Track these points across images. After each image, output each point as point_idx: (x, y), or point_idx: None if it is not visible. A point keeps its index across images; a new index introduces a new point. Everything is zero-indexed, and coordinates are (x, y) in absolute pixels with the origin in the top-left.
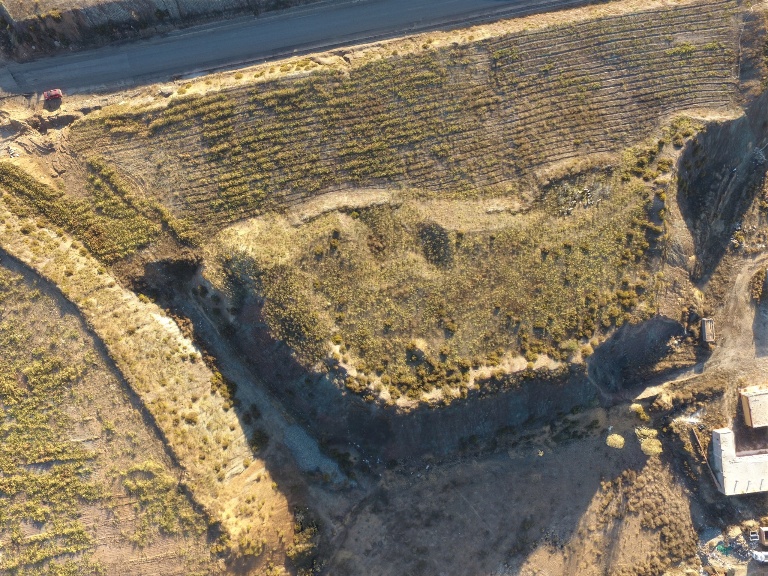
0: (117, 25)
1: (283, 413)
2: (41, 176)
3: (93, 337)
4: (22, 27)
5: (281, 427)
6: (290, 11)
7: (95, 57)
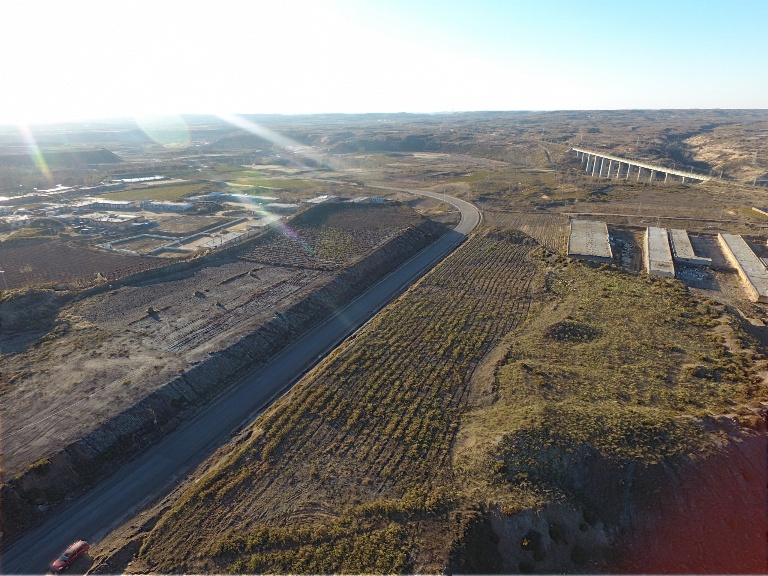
0: (131, 436)
1: None
2: None
3: None
4: None
5: None
6: (287, 348)
7: (114, 484)
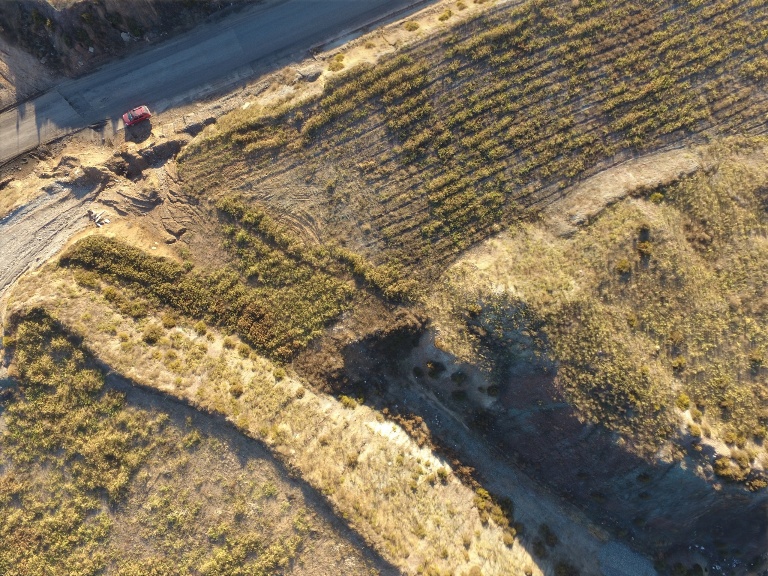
0: None
1: (591, 528)
2: (151, 246)
3: (301, 488)
4: (70, 18)
5: (591, 550)
6: None
7: (186, 45)
